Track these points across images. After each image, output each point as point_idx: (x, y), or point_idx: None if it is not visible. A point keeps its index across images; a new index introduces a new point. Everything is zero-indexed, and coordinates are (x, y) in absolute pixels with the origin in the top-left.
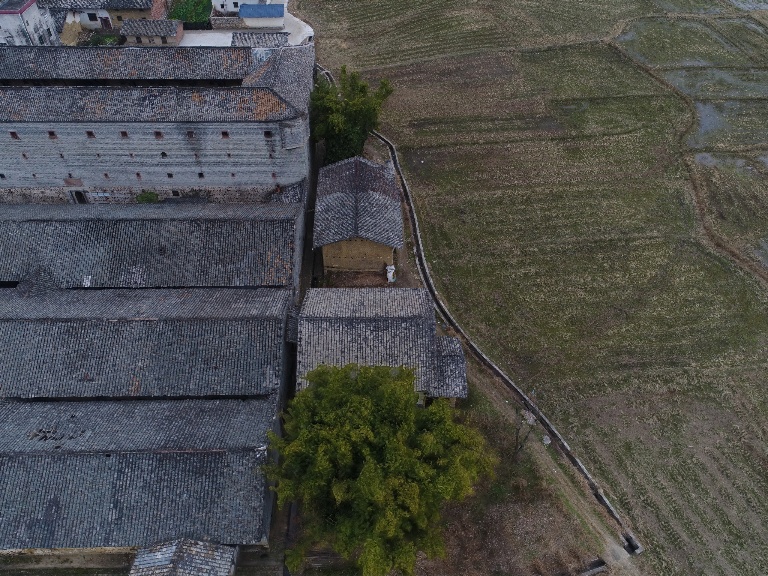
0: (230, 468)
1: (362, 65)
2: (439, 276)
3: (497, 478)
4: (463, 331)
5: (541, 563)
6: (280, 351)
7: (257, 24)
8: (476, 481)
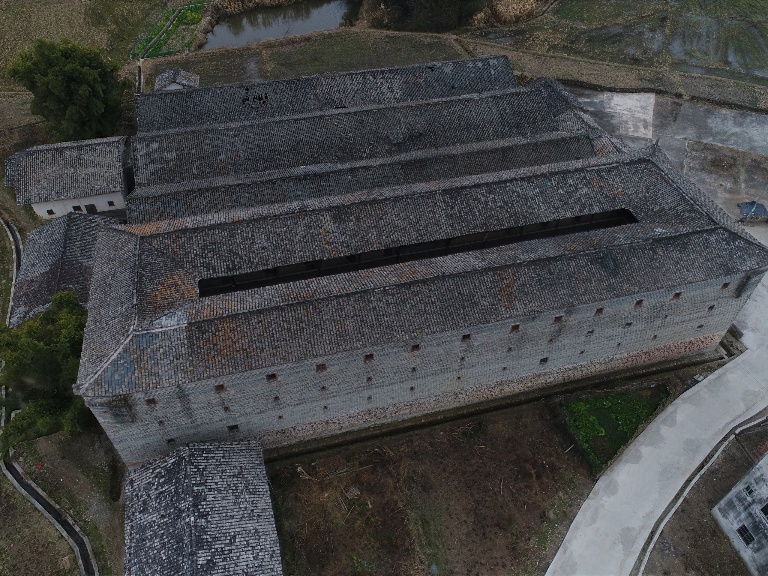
0: None
1: None
2: (5, 267)
3: None
4: (1, 222)
5: (7, 134)
6: None
7: None
8: None
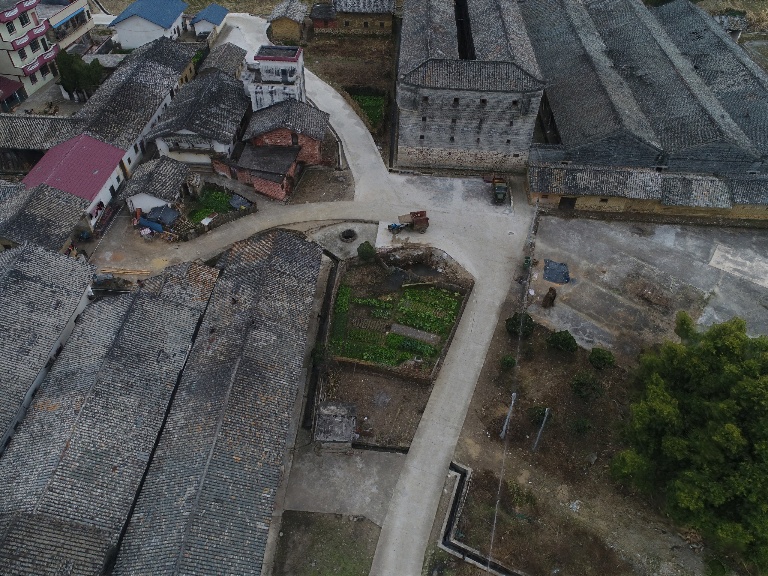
0: (692, 5)
1: (310, 2)
2: None
3: (644, 2)
4: None
5: None
6: (634, 0)
7: (219, 28)
8: (647, 5)
